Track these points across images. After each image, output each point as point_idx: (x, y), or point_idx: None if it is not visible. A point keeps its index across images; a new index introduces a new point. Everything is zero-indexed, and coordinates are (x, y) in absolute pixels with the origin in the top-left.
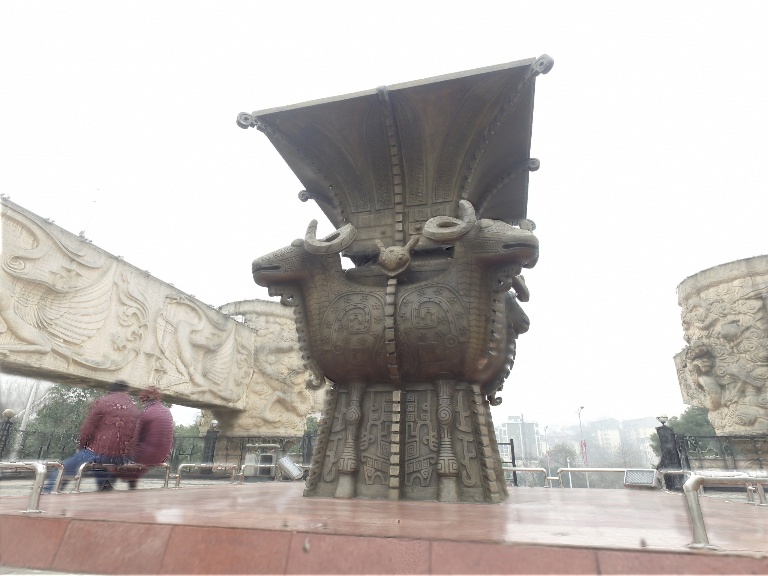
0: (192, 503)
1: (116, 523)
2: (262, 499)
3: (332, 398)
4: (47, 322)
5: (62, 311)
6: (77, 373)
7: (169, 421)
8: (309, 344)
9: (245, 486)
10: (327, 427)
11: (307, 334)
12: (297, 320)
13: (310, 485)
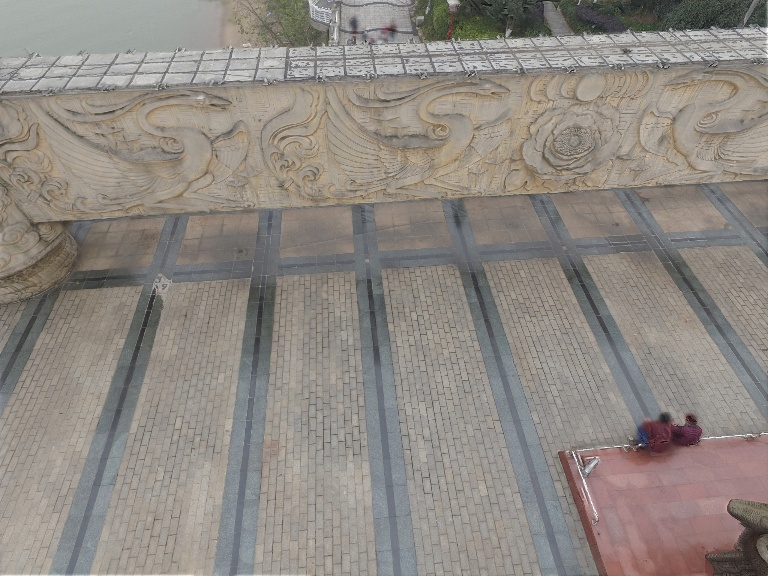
0: (646, 536)
1: (602, 561)
2: (679, 548)
3: (745, 558)
4: (725, 154)
5: (744, 139)
6: (742, 179)
7: (694, 439)
8: (745, 541)
9: (740, 461)
10: (734, 559)
11: (747, 539)
12: (744, 532)
13: (710, 558)
